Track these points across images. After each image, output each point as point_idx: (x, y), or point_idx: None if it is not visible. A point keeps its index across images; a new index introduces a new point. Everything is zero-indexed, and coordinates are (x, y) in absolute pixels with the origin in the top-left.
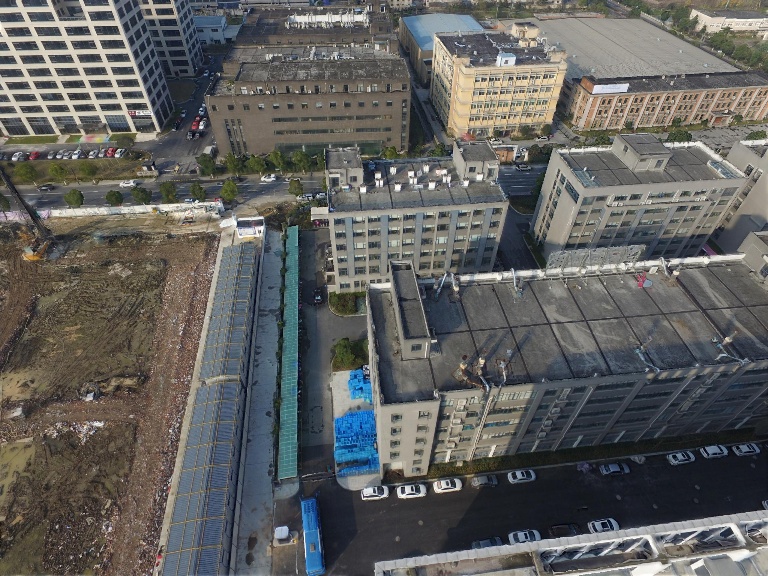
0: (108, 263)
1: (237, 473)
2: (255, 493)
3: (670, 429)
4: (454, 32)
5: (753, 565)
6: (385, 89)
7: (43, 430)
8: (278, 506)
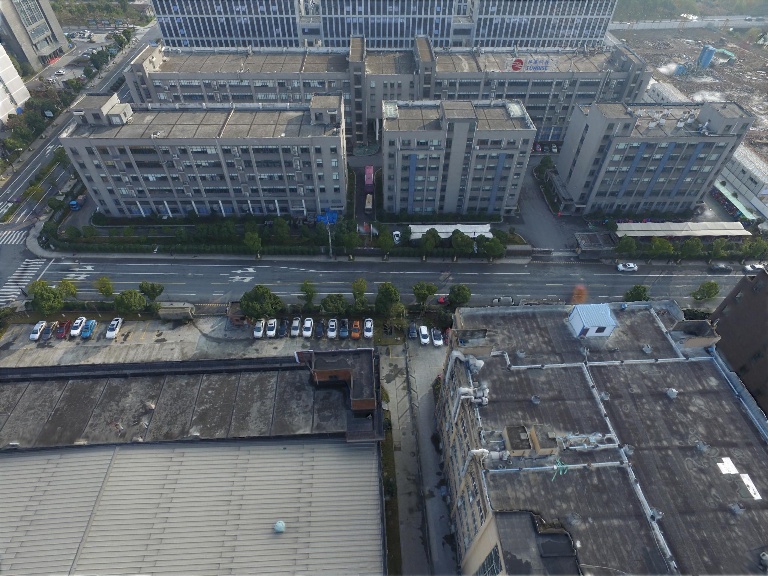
0: None
1: None
2: None
3: None
4: None
5: None
6: None
7: None
8: None
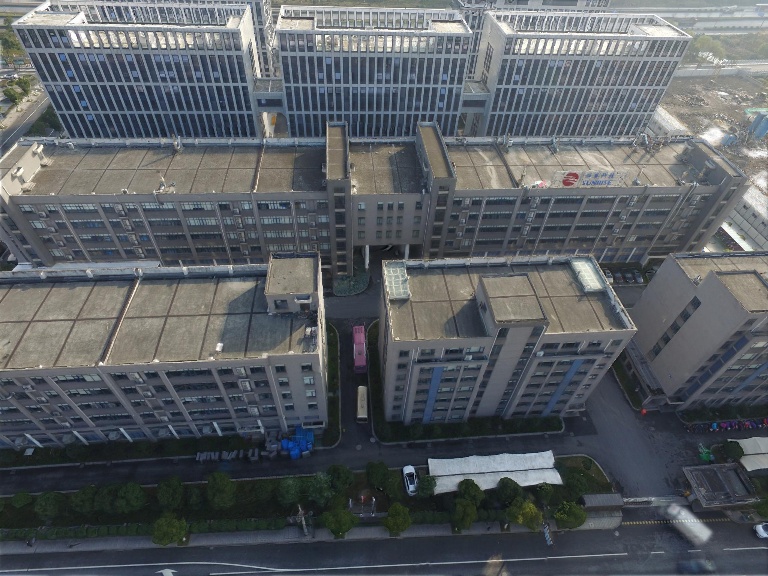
0: None
1: None
2: None
3: None
4: None
5: None
6: None
7: None
8: None
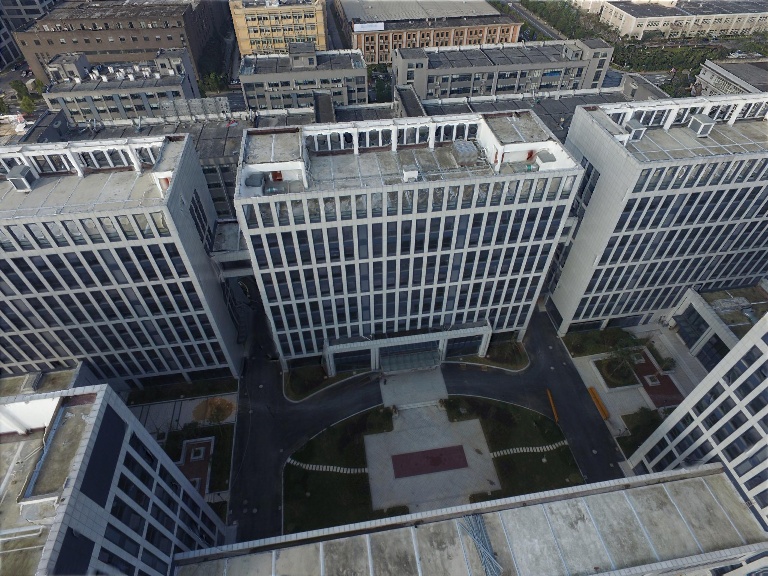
0: None
1: None
2: None
3: None
4: None
5: (59, 180)
6: (164, 26)
7: None
8: None
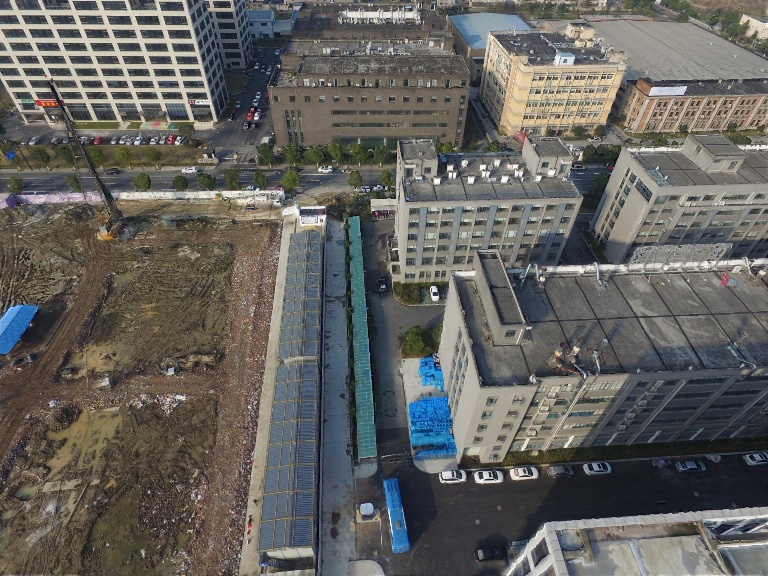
0: (177, 245)
1: (319, 450)
2: (335, 471)
3: (748, 429)
4: (508, 31)
5: None
6: (444, 85)
7: (129, 401)
8: (358, 484)
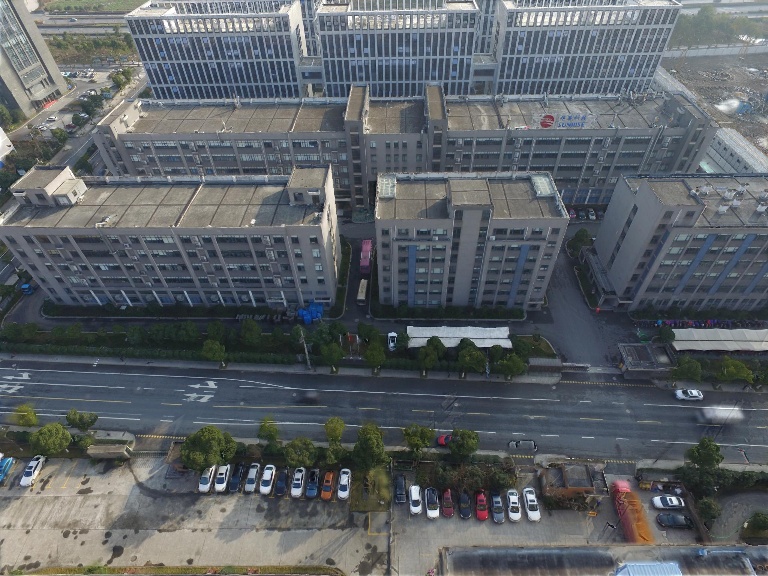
0: None
1: None
2: None
3: None
4: None
5: None
6: None
7: None
8: None
